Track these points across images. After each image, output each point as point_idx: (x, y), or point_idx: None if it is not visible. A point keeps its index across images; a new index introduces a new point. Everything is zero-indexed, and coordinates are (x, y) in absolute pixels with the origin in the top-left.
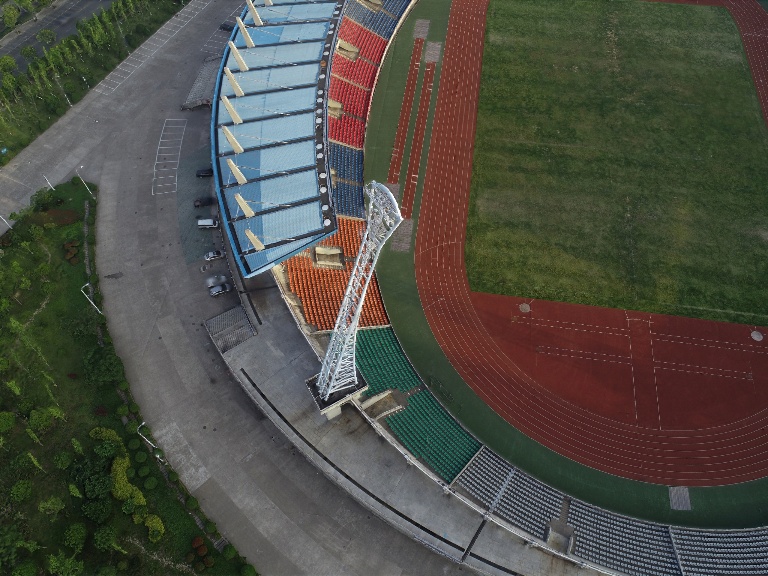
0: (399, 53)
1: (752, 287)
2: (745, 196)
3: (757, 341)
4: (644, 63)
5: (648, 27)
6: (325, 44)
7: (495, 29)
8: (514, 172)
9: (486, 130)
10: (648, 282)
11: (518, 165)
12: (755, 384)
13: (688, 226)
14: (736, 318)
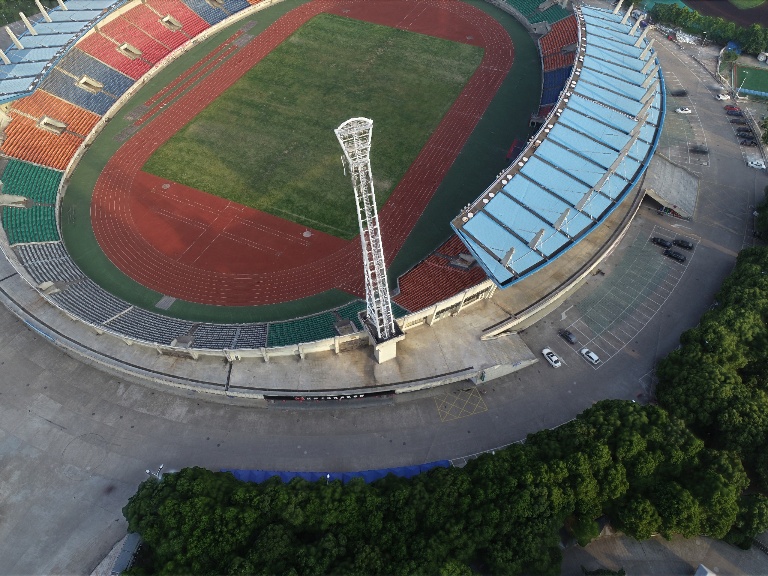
0: (220, 37)
1: (332, 208)
2: (381, 158)
3: (304, 237)
4: (387, 70)
5: (412, 50)
6: (118, 1)
7: (299, 34)
8: (232, 114)
9: (236, 88)
10: (262, 190)
11: (238, 111)
12: (278, 258)
13: (322, 166)
14: (302, 221)
